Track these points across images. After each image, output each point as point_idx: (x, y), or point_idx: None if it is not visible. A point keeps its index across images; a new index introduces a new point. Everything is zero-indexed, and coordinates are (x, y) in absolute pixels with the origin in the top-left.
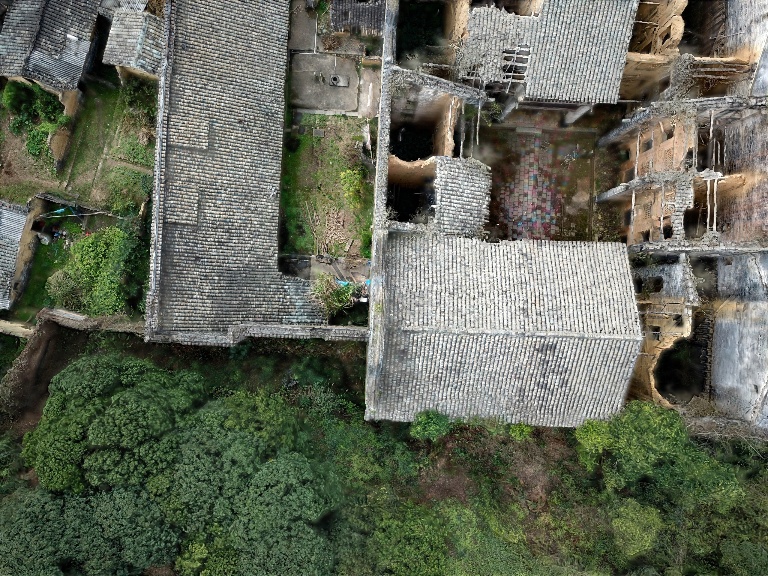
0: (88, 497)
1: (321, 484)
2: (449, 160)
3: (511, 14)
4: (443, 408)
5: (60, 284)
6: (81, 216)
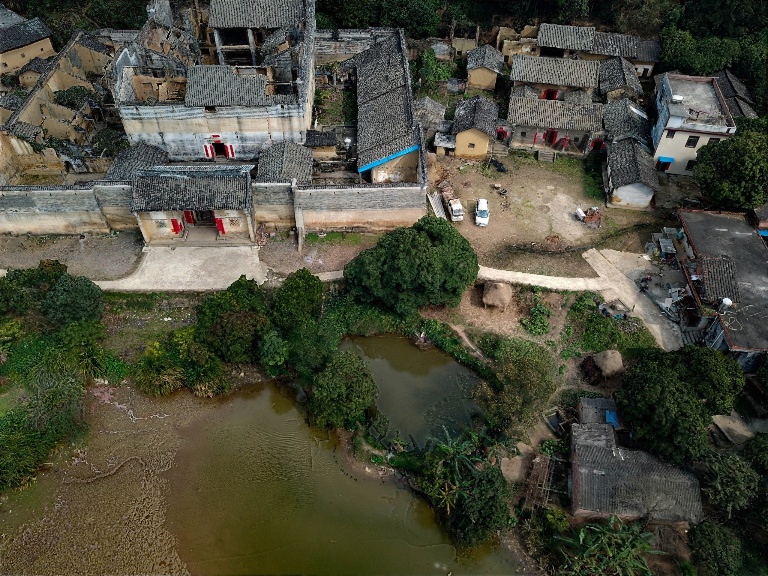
0: None
1: None
2: None
3: (249, 67)
4: None
5: (450, 62)
6: None
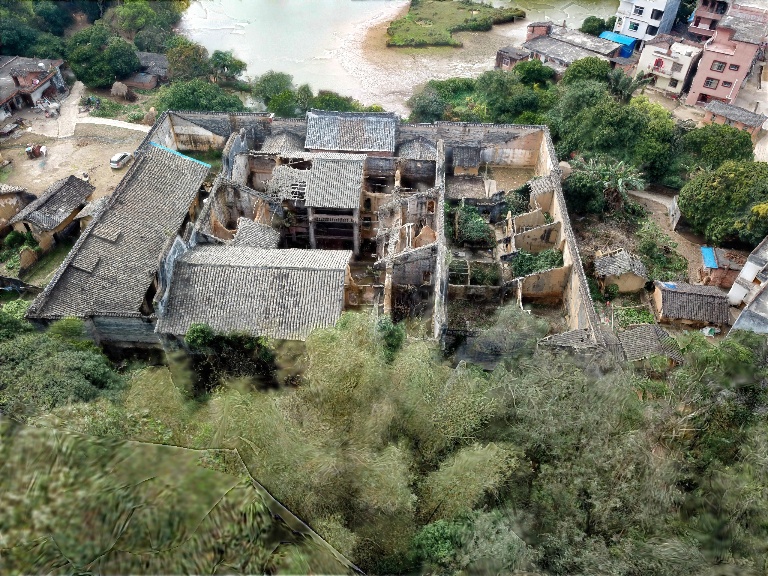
0: None
1: (107, 368)
2: (249, 220)
3: (295, 169)
4: (212, 324)
5: None
6: (21, 292)
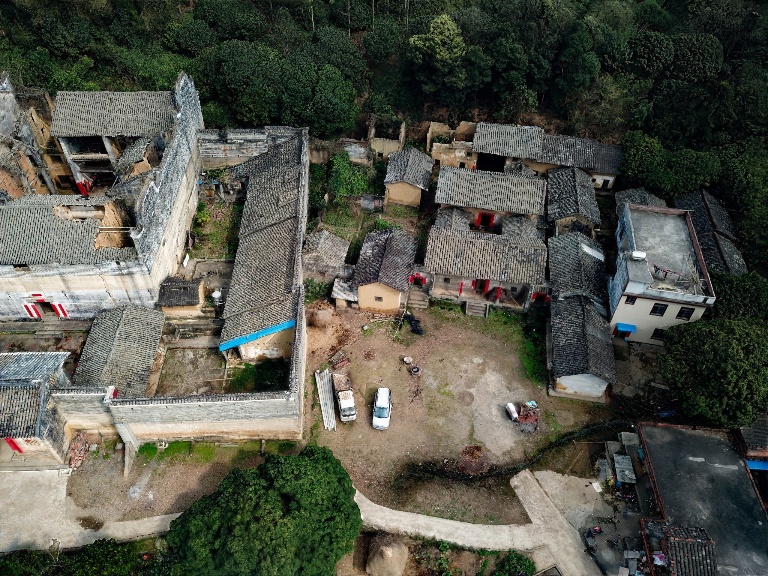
0: (317, 66)
1: None
2: None
3: (80, 205)
4: None
5: (367, 168)
6: None
